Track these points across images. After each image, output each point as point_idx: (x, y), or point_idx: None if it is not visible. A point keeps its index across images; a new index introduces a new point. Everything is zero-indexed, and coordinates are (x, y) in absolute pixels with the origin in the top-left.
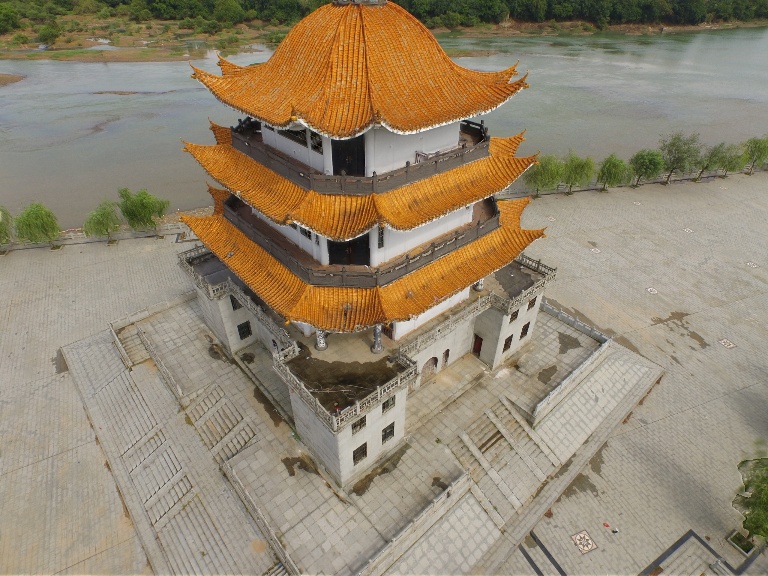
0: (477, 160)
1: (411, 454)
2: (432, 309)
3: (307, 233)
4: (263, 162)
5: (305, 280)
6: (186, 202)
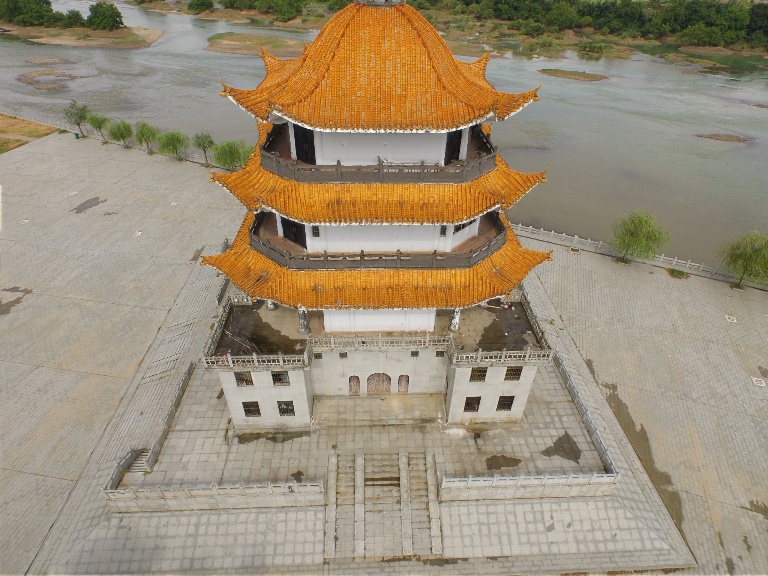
0: (443, 183)
1: (304, 441)
2: (376, 321)
3: None
4: None
5: None
6: None
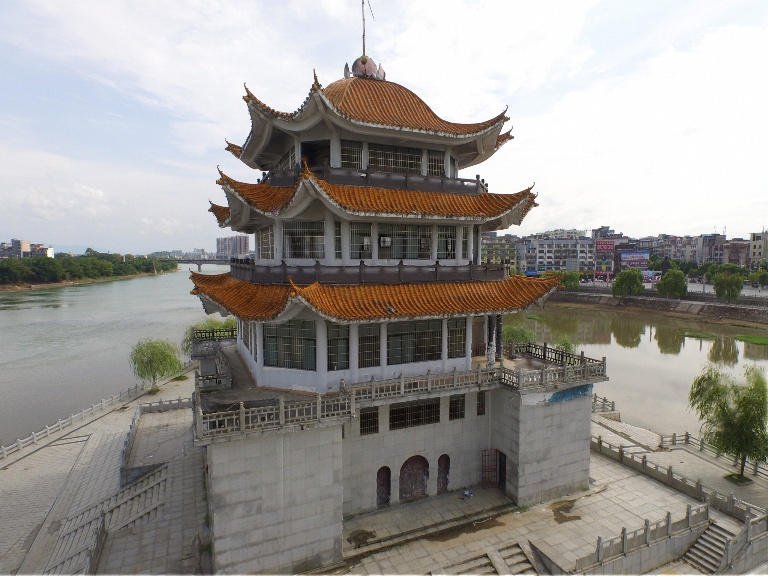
0: None
1: None
2: None
3: (449, 253)
4: (400, 187)
5: (498, 279)
6: None
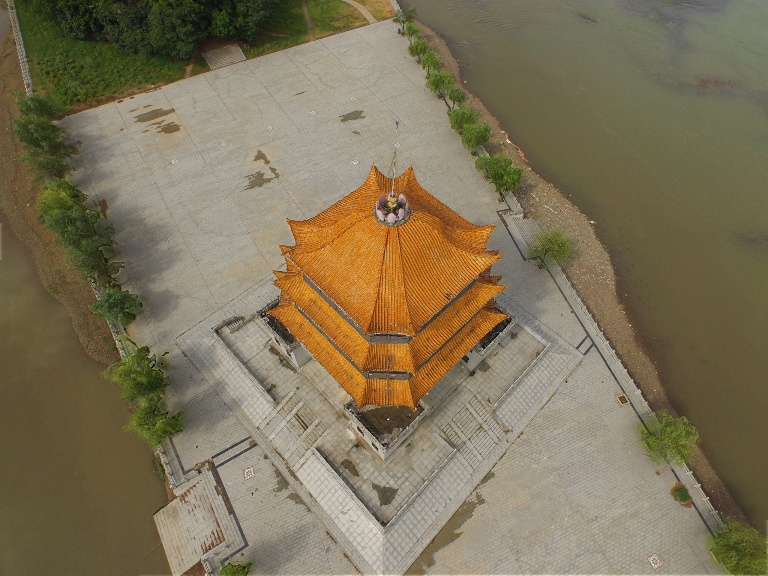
0: (360, 334)
1: (290, 373)
2: None
3: None
4: None
5: None
6: (585, 196)
